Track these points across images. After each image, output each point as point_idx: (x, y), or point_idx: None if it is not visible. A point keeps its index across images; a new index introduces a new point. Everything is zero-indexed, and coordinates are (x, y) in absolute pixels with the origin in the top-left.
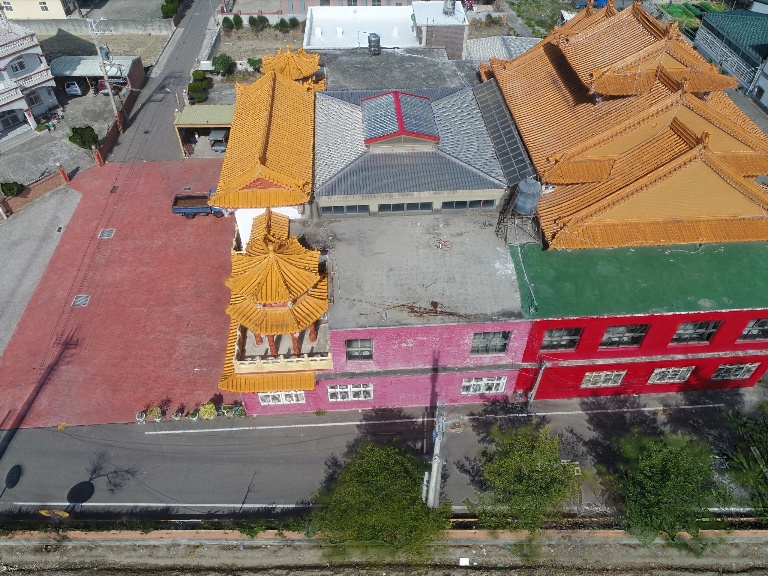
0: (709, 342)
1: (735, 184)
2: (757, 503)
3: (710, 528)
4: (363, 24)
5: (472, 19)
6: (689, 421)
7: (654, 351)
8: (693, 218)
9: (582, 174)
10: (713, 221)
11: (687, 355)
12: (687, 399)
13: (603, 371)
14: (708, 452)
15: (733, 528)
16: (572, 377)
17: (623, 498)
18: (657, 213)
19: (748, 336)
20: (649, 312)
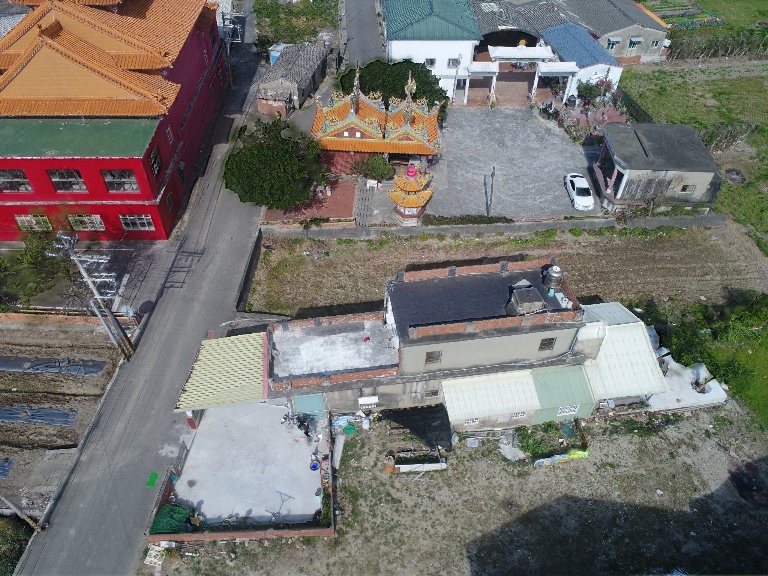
0: (88, 191)
1: (86, 68)
2: None
3: None
4: None
5: None
6: None
7: (49, 197)
8: (79, 97)
9: (4, 63)
10: (96, 101)
11: (78, 202)
12: (110, 245)
13: (28, 215)
14: None
15: (50, 314)
16: (5, 219)
17: (1, 299)
18: (48, 92)
19: None
20: (3, 156)
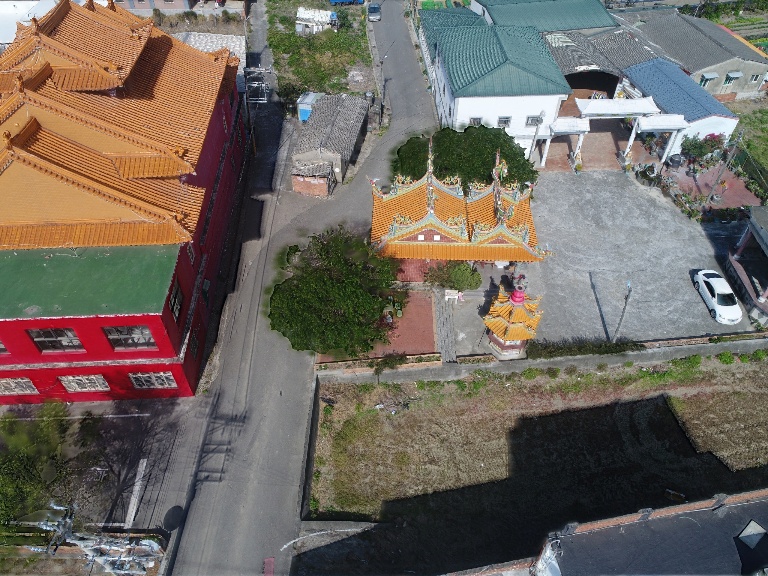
0: None
1: (76, 187)
2: (102, 518)
3: (14, 544)
4: (17, 19)
5: (209, 15)
6: (100, 431)
7: (32, 359)
8: (67, 221)
9: None
10: (92, 225)
11: (72, 363)
12: (117, 408)
13: (4, 378)
14: (93, 464)
15: (38, 544)
16: None
17: None
18: (24, 216)
19: (138, 344)
20: None
